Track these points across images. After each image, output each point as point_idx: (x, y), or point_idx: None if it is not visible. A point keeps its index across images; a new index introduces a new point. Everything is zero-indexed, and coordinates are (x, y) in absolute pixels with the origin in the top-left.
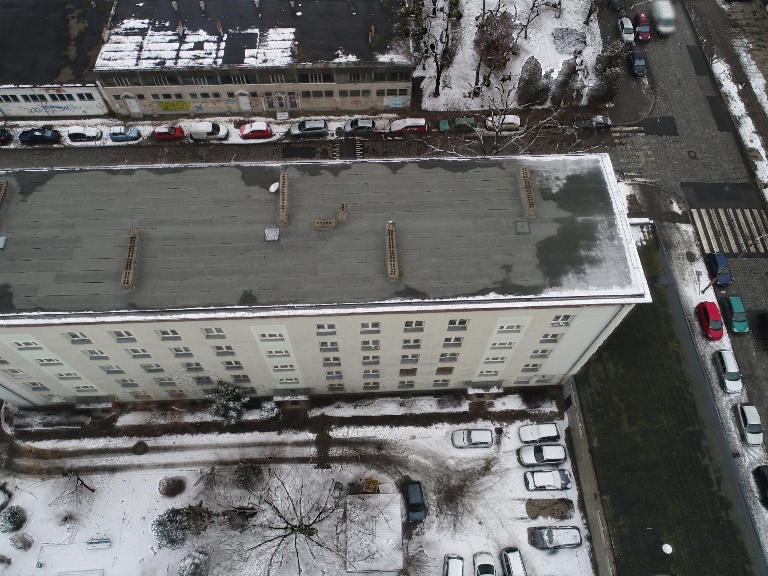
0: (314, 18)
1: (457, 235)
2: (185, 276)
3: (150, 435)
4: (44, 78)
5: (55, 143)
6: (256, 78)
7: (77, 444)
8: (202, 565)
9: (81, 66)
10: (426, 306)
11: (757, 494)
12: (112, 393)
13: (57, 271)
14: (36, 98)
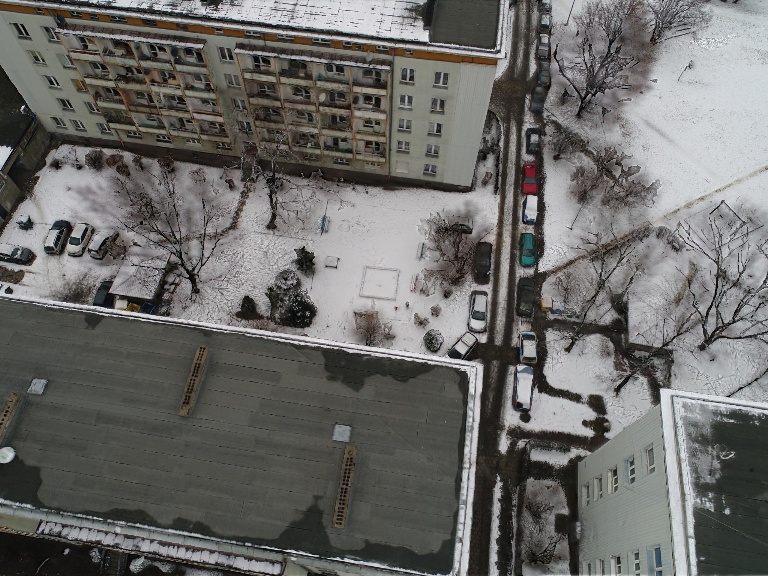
0: None
1: None
2: (147, 356)
3: None
4: None
5: None
6: None
7: None
8: (280, 278)
9: None
10: None
11: None
12: None
13: (278, 386)
14: None
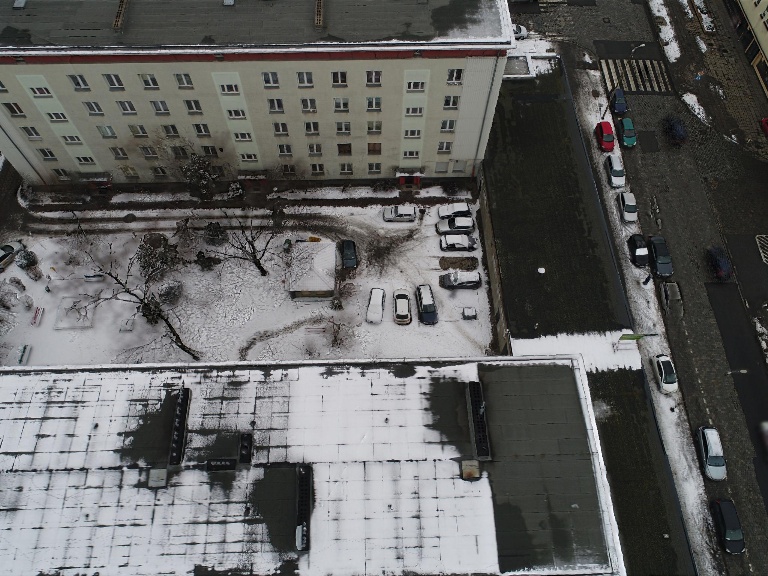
0: None
1: (371, 4)
2: (161, 26)
3: (138, 209)
4: None
5: None
6: None
7: (79, 215)
8: (176, 288)
9: None
10: (343, 48)
11: (629, 256)
12: (107, 169)
13: (64, 22)
14: None
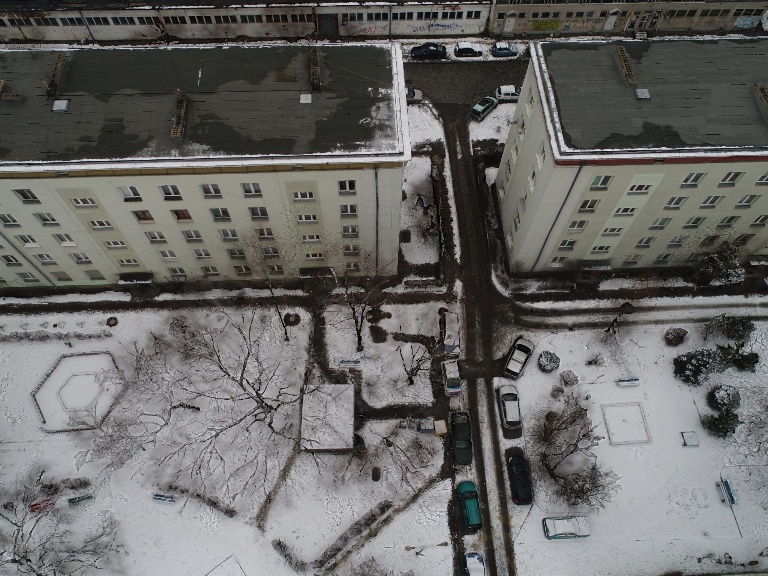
0: None
1: None
2: None
3: (633, 298)
4: None
5: (443, 58)
6: None
7: (571, 305)
8: (736, 396)
9: None
10: None
11: None
12: (614, 256)
13: (705, 116)
14: (428, 16)
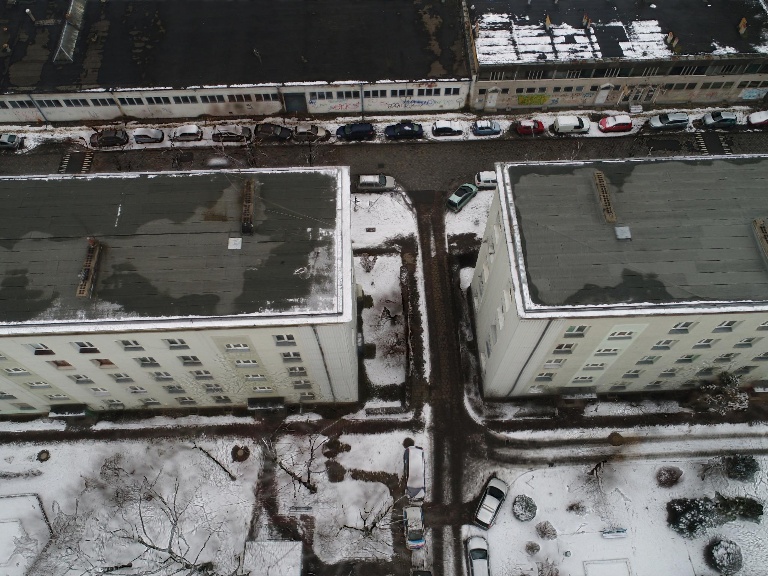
0: (671, 10)
1: None
2: None
3: (622, 426)
4: (417, 73)
5: (419, 138)
6: (630, 71)
7: (552, 435)
8: (737, 555)
9: (449, 61)
10: None
11: None
12: (599, 384)
13: (695, 261)
14: (403, 93)
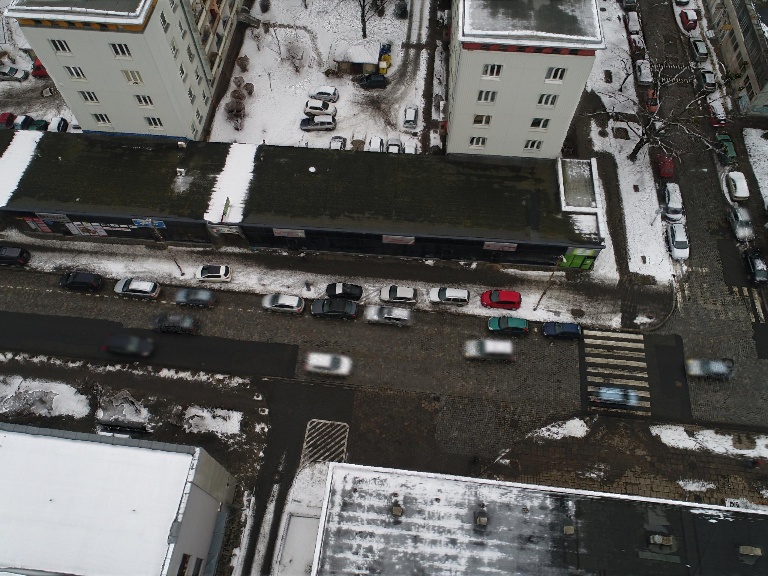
0: None
1: None
2: None
3: None
4: None
5: None
6: None
7: None
8: None
9: None
10: None
11: None
12: None
13: None
14: None
